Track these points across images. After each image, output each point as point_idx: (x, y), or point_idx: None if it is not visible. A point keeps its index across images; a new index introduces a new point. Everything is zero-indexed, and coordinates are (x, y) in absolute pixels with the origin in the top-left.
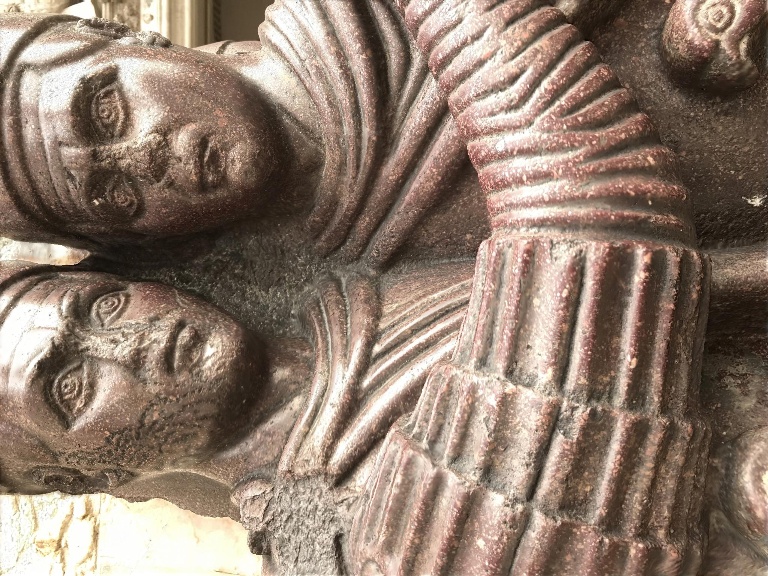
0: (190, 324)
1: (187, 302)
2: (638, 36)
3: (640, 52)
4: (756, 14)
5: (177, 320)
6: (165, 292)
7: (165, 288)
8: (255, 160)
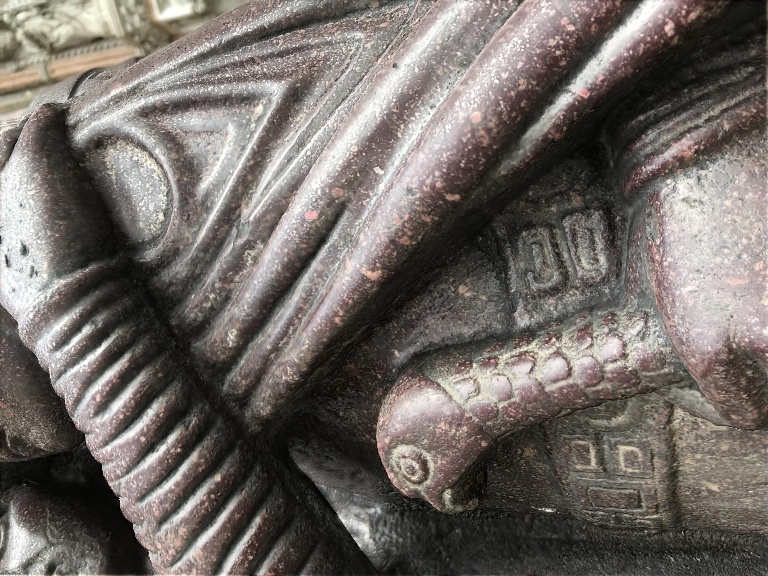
0: (59, 565)
1: (56, 533)
2: (373, 384)
3: (380, 399)
4: (451, 477)
5: (46, 565)
6: (36, 521)
7: (38, 512)
8: (56, 438)
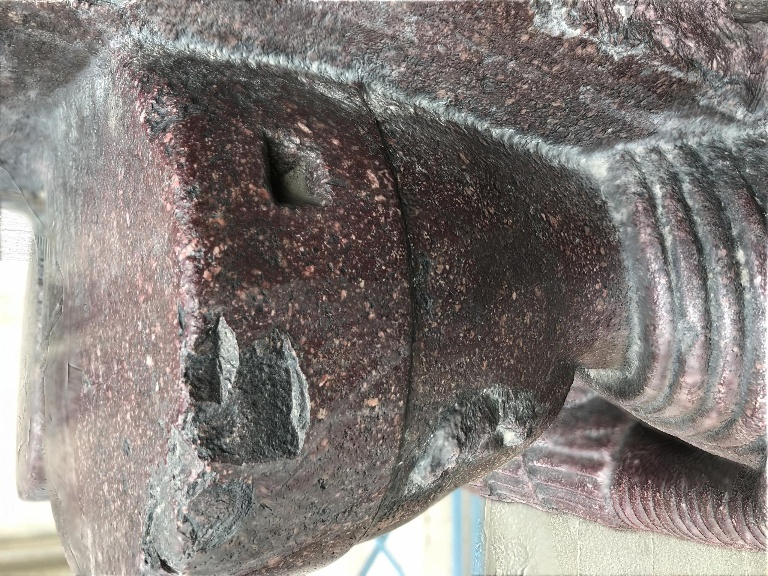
0: None
1: None
2: None
3: None
4: None
5: None
6: None
7: None
8: None
